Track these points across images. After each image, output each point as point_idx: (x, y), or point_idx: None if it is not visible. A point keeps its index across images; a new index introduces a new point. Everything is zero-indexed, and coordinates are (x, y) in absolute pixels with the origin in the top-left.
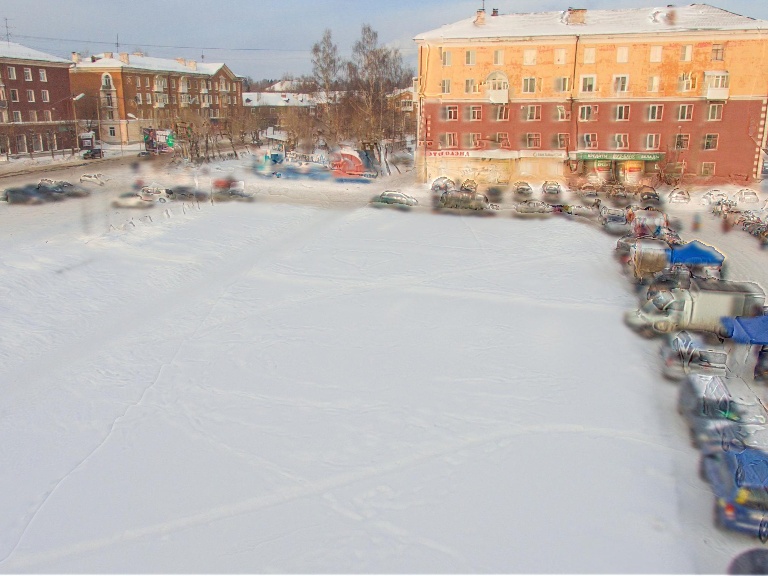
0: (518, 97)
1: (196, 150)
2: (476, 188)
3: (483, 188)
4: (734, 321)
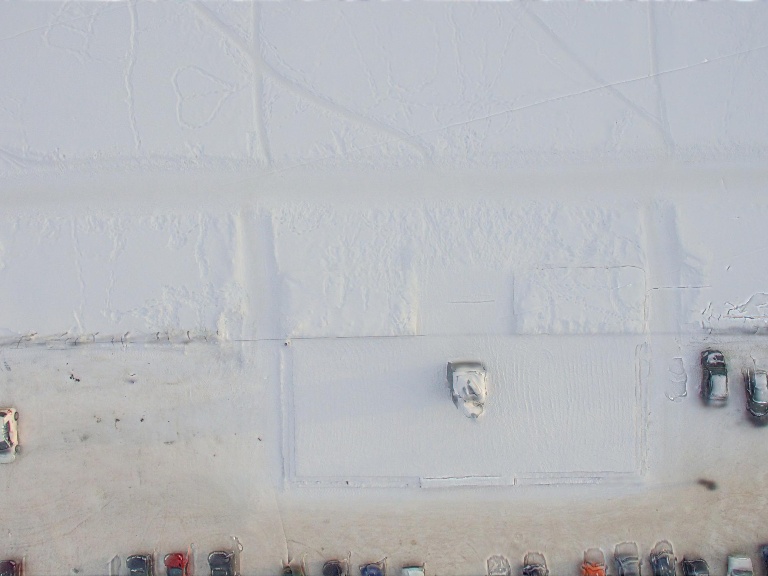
0: None
1: None
2: None
3: None
4: None
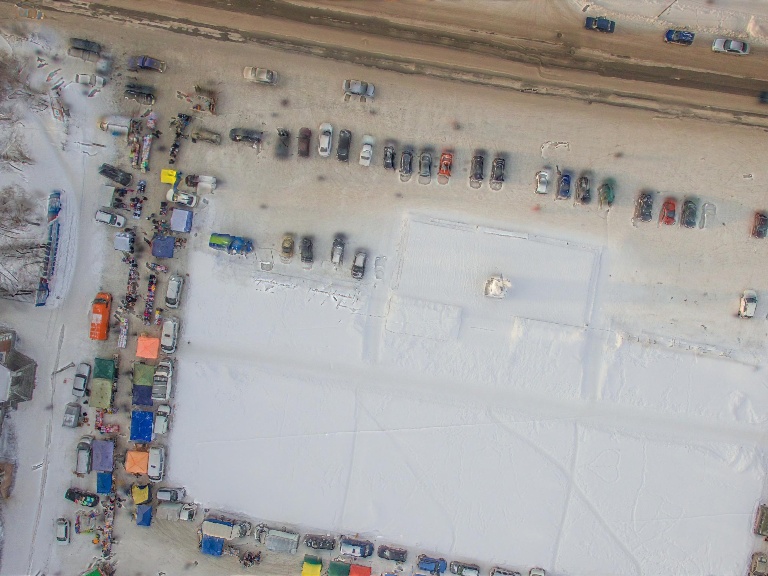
0: None
1: None
2: None
3: None
4: None
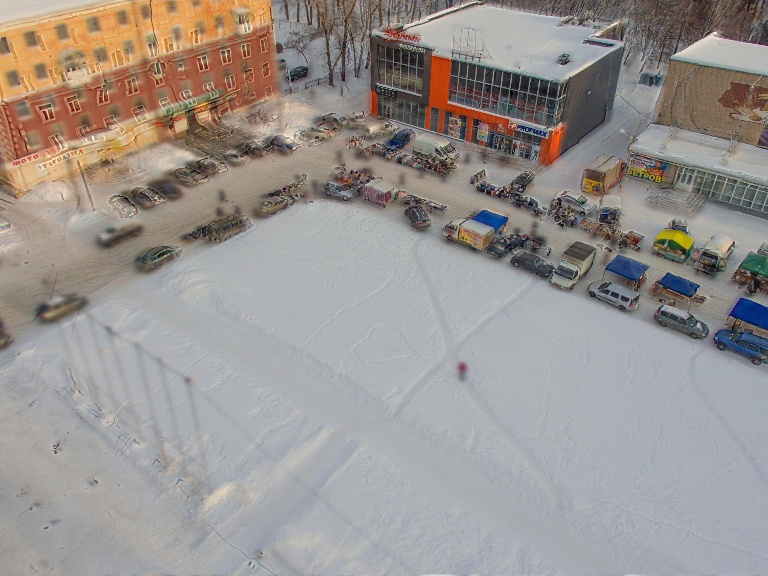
0: (112, 75)
1: None
2: None
3: None
4: (609, 272)
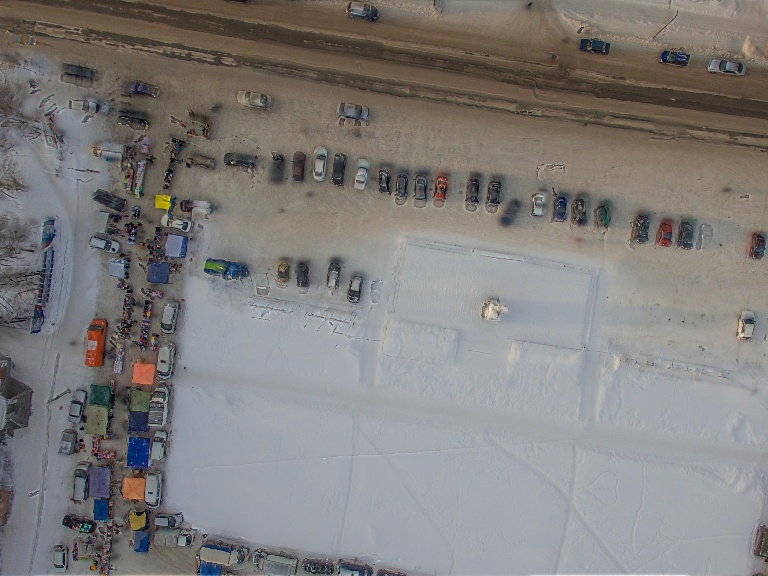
0: None
1: None
2: None
3: None
4: None
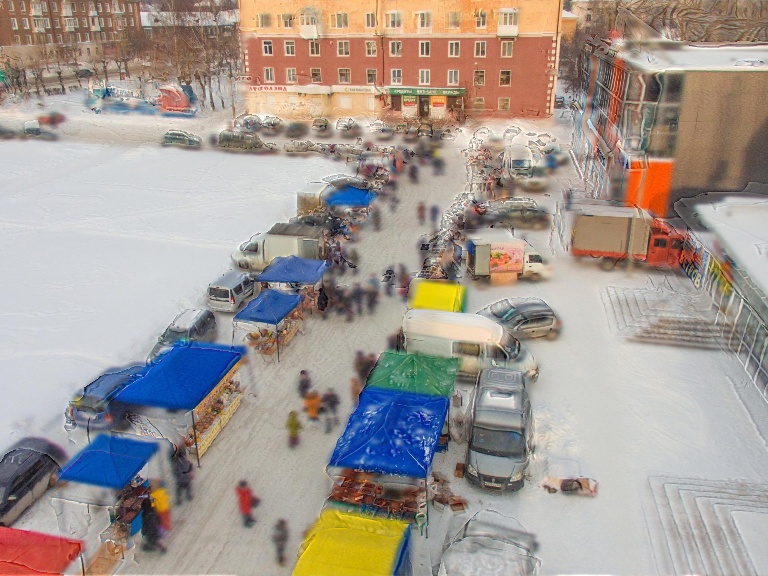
0: (327, 32)
1: (18, 85)
2: (276, 125)
3: (288, 124)
4: None
